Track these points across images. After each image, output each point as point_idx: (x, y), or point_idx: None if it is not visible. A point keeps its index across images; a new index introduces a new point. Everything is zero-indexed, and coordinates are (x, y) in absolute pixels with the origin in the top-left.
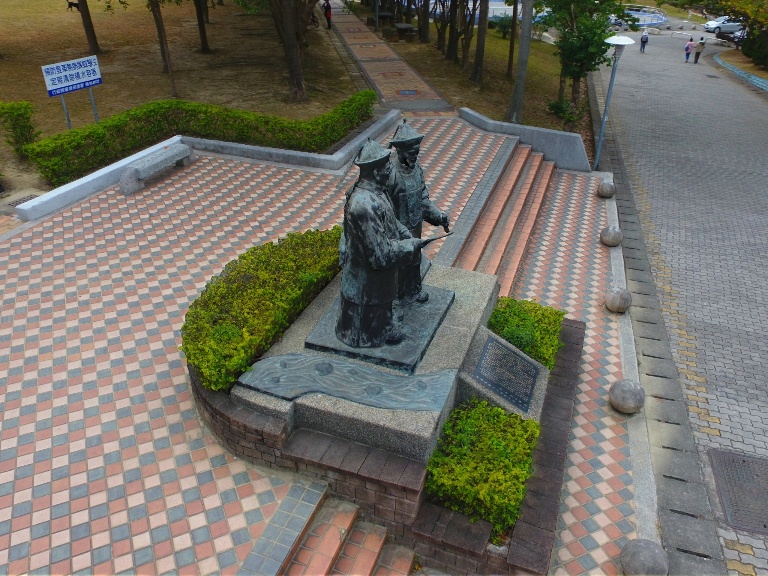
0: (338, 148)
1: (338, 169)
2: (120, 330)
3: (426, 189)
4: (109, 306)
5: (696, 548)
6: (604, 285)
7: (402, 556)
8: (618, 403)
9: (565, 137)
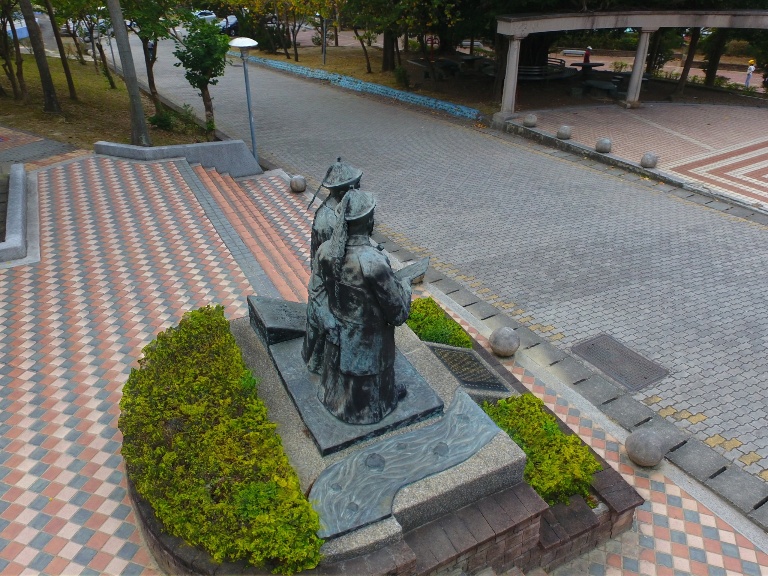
0: None
1: (25, 256)
2: None
3: None
4: None
5: (641, 418)
6: None
7: None
8: (507, 350)
9: (230, 146)
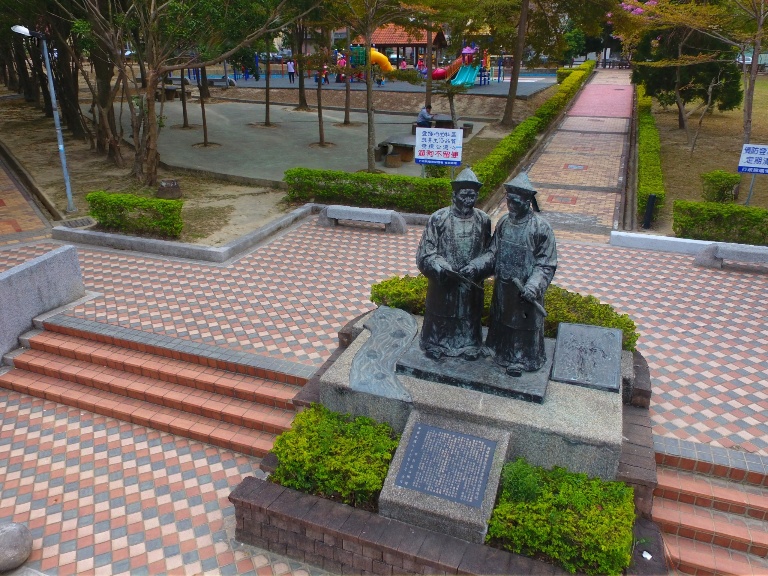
0: None
1: None
2: None
3: (547, 258)
4: None
5: None
6: None
7: None
8: None
9: None
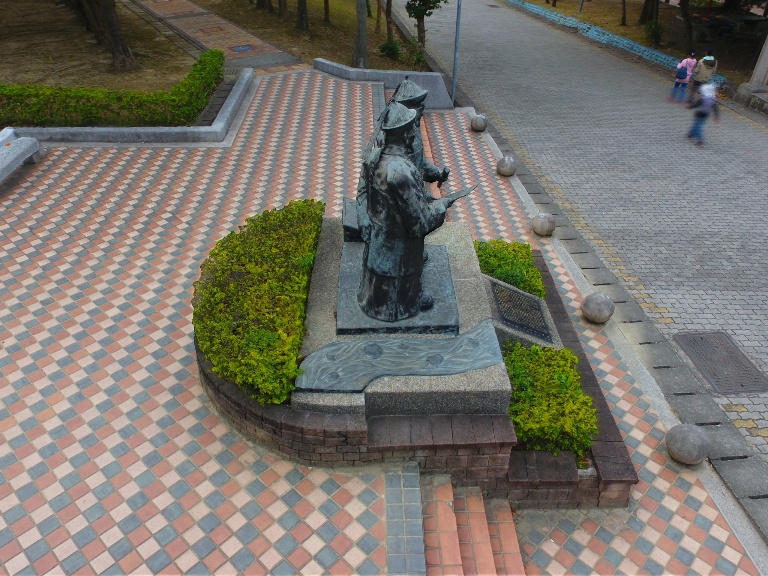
0: (207, 117)
1: (223, 140)
2: (84, 369)
3: None
4: (50, 345)
5: (708, 419)
6: (522, 213)
7: (500, 508)
8: (595, 316)
9: (427, 77)
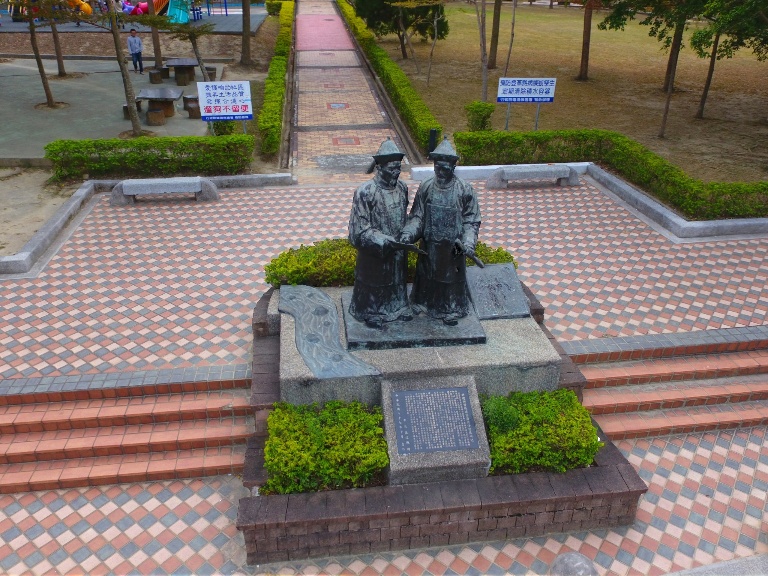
0: None
1: (682, 237)
2: None
3: (474, 215)
4: None
5: None
6: None
7: None
8: None
9: None
